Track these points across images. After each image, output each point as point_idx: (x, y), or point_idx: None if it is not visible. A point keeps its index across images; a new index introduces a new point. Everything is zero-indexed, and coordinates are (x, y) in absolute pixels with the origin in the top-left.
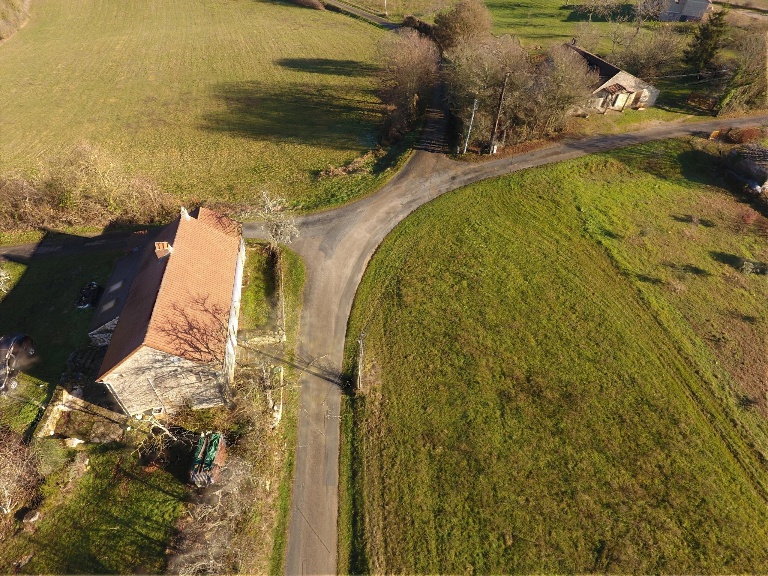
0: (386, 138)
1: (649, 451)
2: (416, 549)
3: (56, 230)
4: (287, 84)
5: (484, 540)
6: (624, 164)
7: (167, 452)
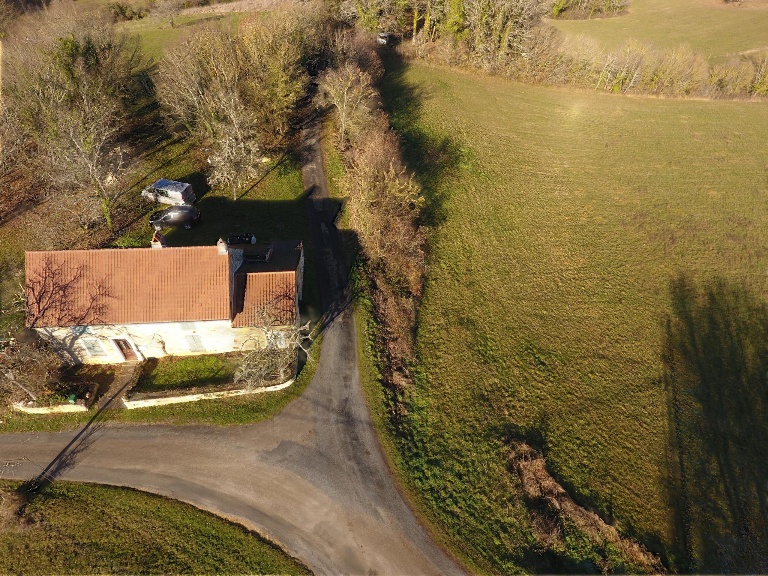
0: None
1: None
2: None
3: (346, 201)
4: None
5: None
6: None
7: None
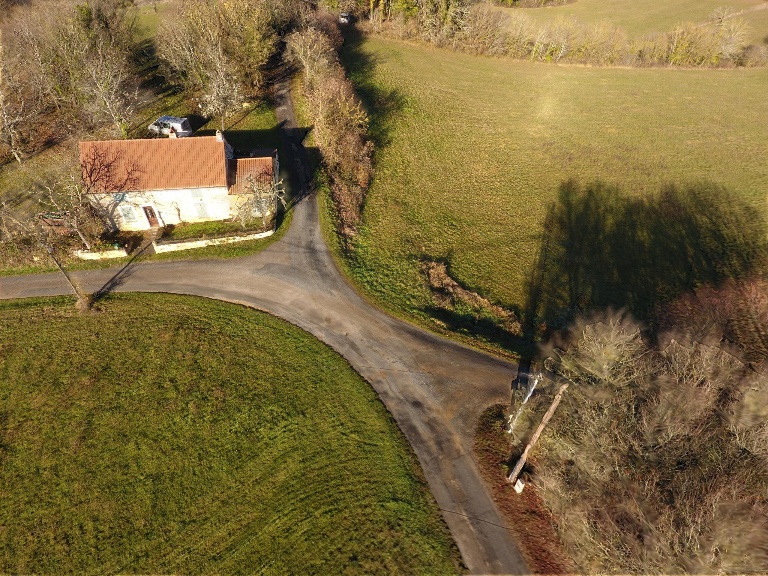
0: (565, 333)
1: None
2: None
3: (311, 129)
4: (766, 240)
5: None
6: None
7: None
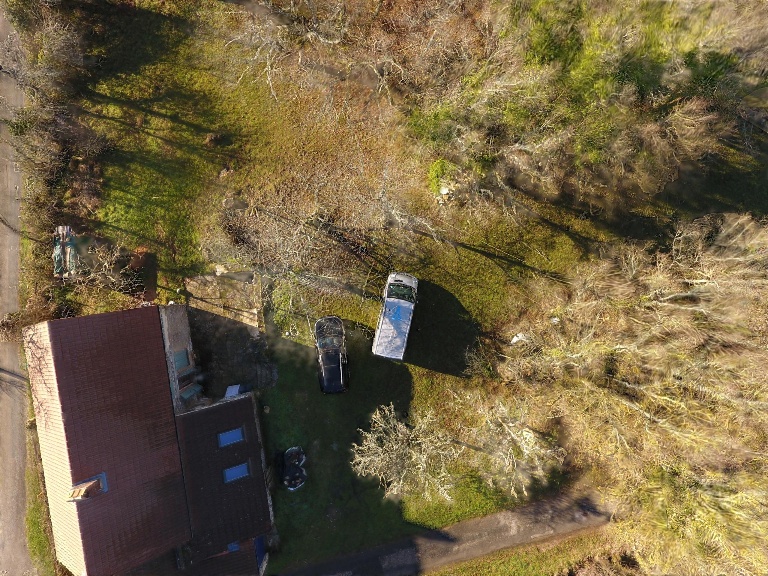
0: None
1: None
2: None
3: None
4: None
5: None
6: None
7: None
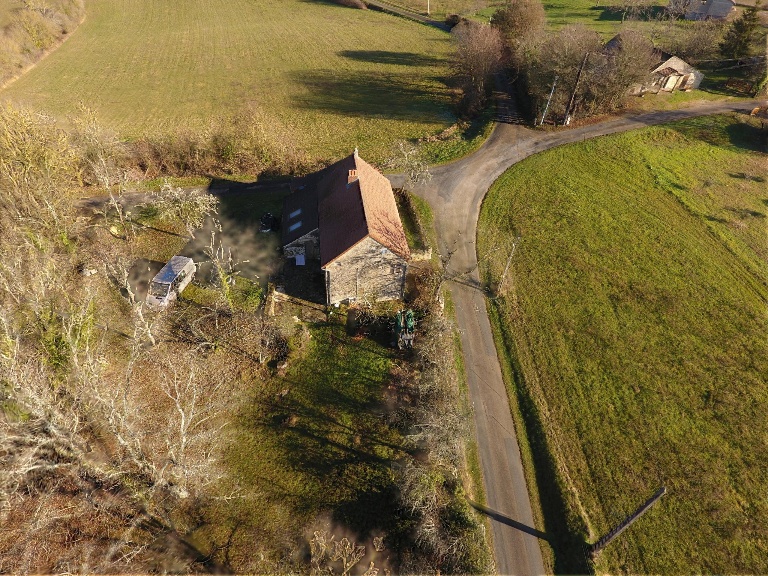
0: (466, 114)
1: (734, 335)
2: (568, 394)
3: (219, 177)
4: (356, 72)
5: (618, 389)
6: (681, 133)
7: (367, 328)
